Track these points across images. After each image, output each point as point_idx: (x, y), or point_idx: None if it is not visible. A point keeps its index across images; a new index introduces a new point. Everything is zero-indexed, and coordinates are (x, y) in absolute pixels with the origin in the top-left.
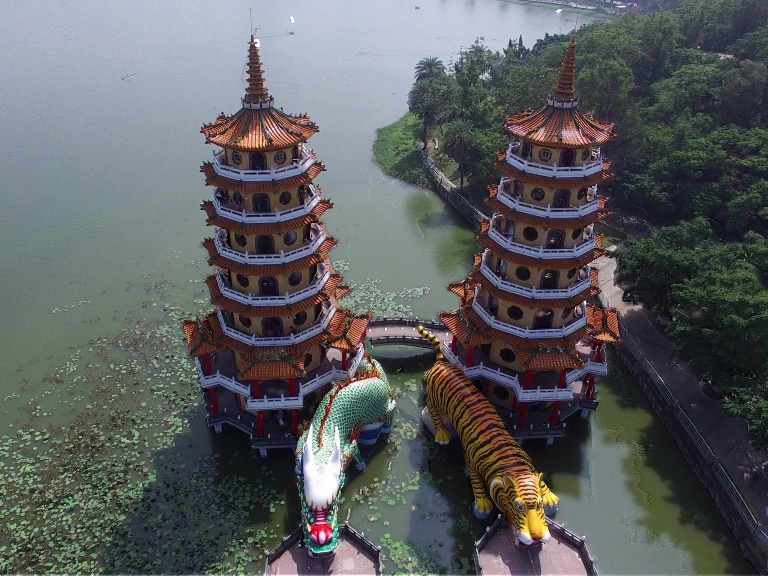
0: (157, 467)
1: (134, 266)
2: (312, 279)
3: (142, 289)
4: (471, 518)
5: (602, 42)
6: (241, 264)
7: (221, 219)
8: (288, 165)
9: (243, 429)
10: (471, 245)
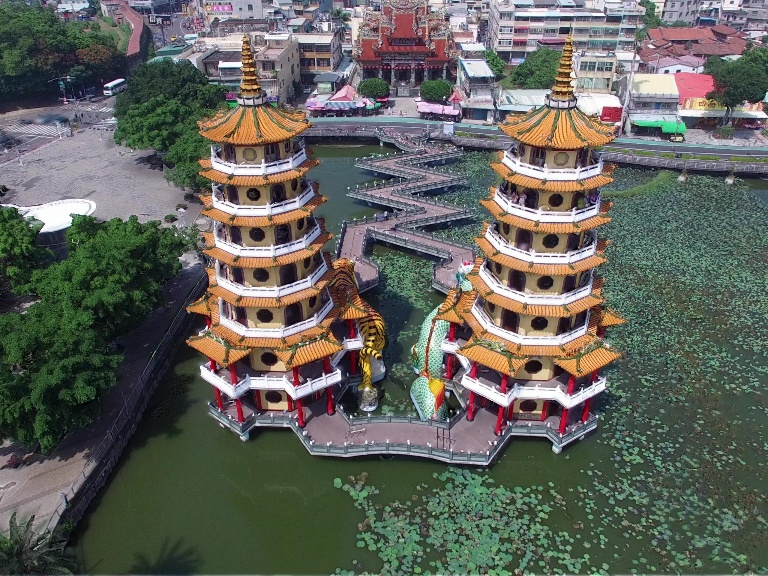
0: None
1: None
2: None
3: None
4: None
5: None
6: None
7: None
8: None
9: None
10: None
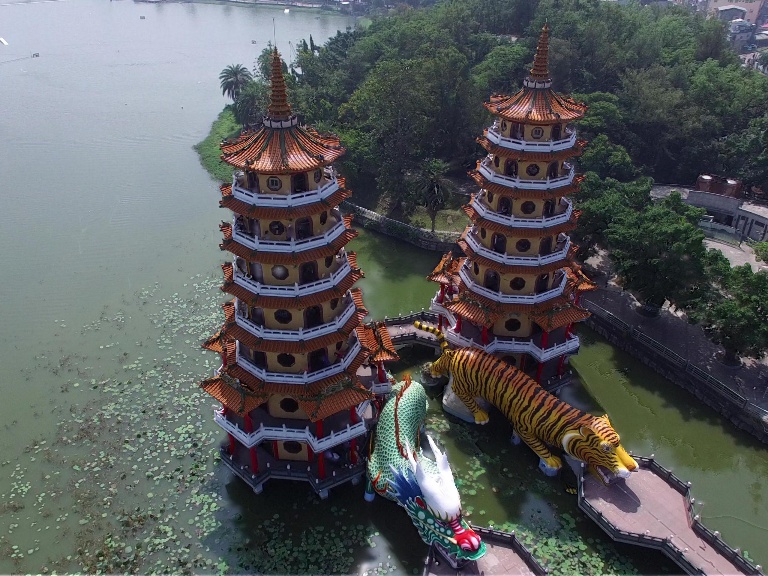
0: (219, 554)
1: (14, 350)
2: None
3: (46, 373)
4: (545, 479)
5: (411, 34)
6: (291, 298)
7: (262, 254)
8: (327, 182)
9: (294, 478)
10: (368, 241)
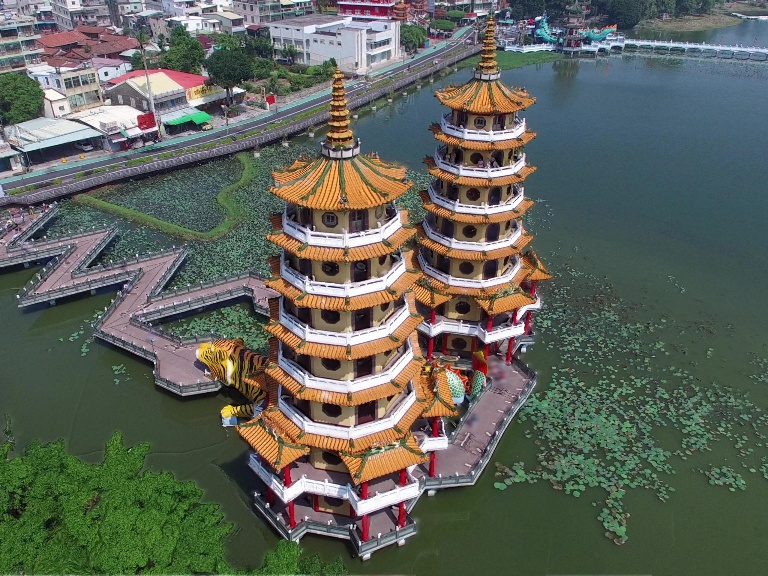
0: None
1: (760, 325)
2: (445, 234)
3: None
4: None
5: None
6: None
7: None
8: (448, 121)
9: None
10: None
